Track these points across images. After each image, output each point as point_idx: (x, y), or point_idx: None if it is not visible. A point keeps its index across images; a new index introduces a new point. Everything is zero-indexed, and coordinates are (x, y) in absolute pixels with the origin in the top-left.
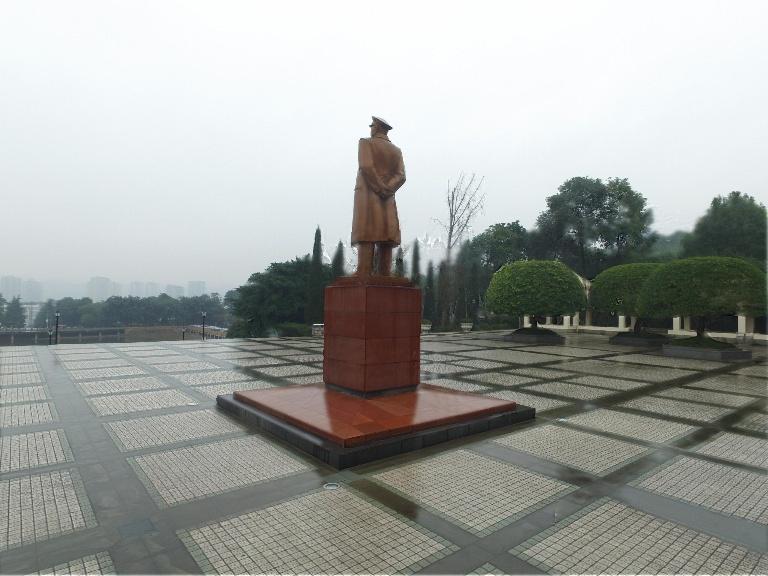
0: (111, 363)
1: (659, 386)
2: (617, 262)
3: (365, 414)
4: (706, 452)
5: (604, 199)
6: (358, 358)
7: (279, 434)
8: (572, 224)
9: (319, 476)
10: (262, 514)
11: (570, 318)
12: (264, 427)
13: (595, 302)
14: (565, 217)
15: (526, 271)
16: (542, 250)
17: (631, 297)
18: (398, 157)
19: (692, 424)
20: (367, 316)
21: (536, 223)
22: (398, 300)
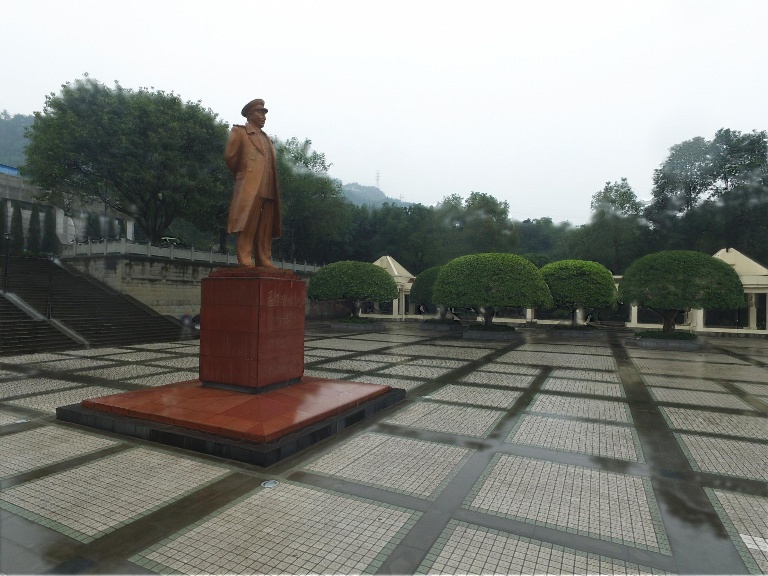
0: None
1: None
2: None
3: None
4: None
5: None
6: None
7: None
8: None
9: None
10: None
11: None
12: None
13: None
14: None
15: None
16: None
17: None
18: None
19: None
20: None
21: None
22: None
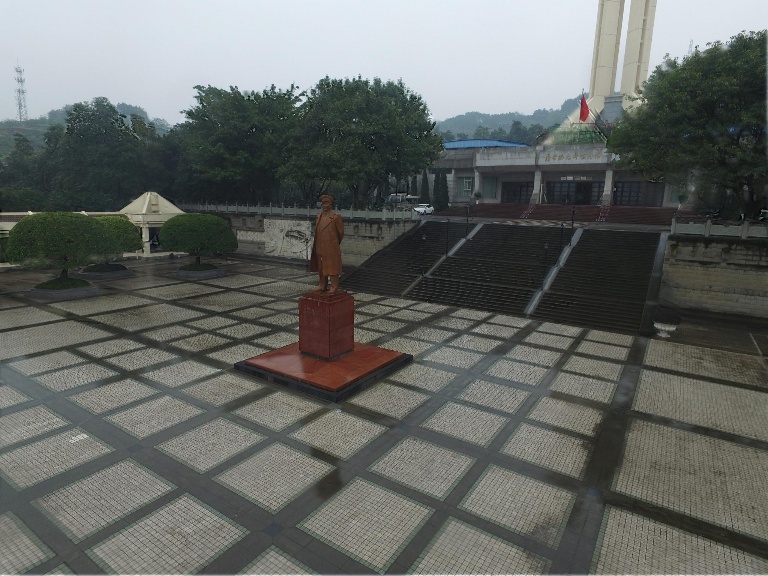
0: None
1: None
2: None
3: None
4: None
5: None
6: None
7: None
8: None
9: None
10: None
11: None
12: None
13: None
14: None
15: None
16: None
17: None
18: None
19: None
20: None
21: None
22: None
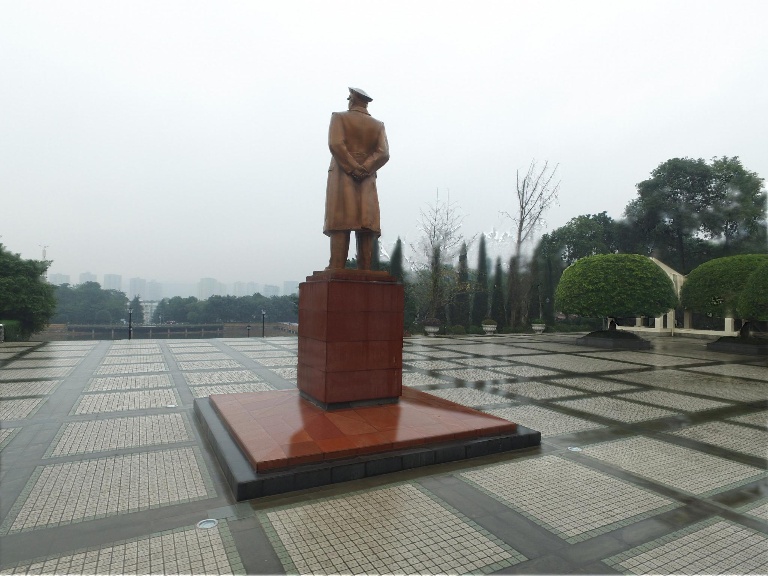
0: (146, 359)
1: (743, 408)
2: (725, 255)
3: (309, 431)
4: (762, 515)
5: (708, 182)
6: (321, 364)
7: (214, 448)
8: (666, 212)
9: (207, 508)
10: (89, 557)
11: (663, 320)
12: (209, 438)
13: (688, 301)
14: (657, 204)
15: (600, 266)
16: (632, 243)
17: (733, 295)
18: (378, 132)
19: (763, 467)
20: (329, 316)
21: (624, 213)
22: (371, 297)
